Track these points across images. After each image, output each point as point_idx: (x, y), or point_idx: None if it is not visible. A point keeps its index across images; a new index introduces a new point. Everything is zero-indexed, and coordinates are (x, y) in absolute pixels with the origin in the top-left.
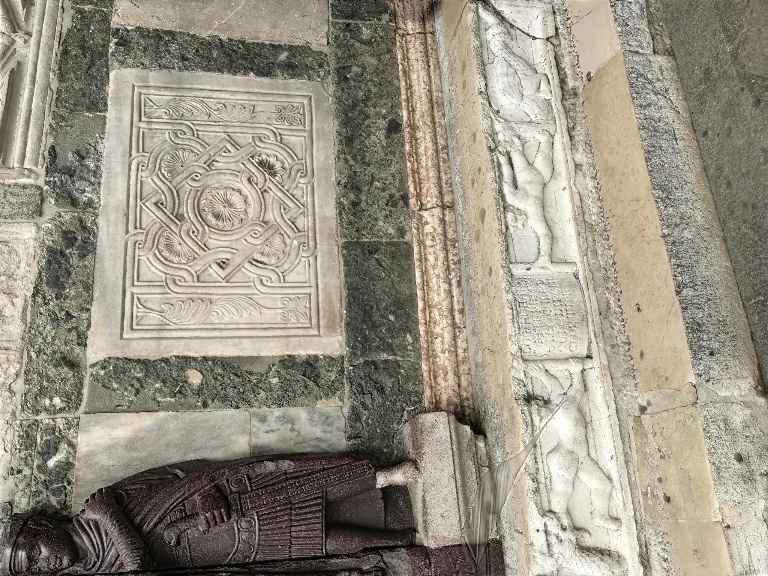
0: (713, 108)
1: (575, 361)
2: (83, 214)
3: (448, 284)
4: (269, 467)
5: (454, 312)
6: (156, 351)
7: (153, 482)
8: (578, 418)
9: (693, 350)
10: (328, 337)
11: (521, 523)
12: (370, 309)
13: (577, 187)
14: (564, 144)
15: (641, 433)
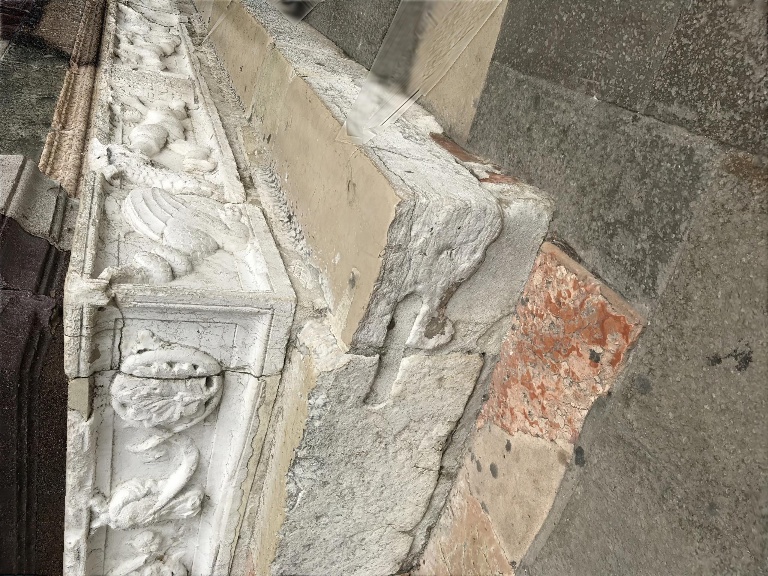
0: None
1: (176, 99)
2: None
3: (78, 155)
4: None
5: (81, 170)
6: None
7: None
8: (171, 115)
9: None
10: None
11: None
12: None
13: None
14: (186, 43)
15: (249, 130)
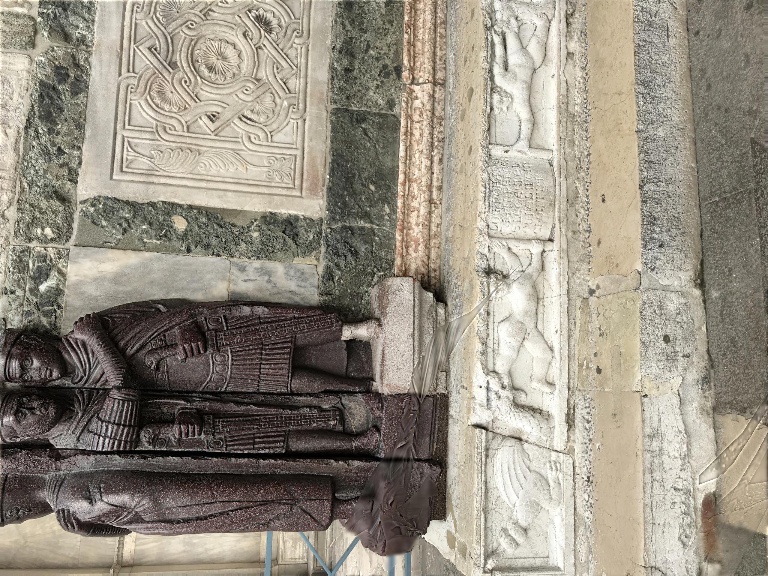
0: (709, 7)
1: (537, 242)
2: (76, 51)
3: (430, 160)
4: (245, 311)
5: (432, 188)
6: (144, 195)
7: (137, 313)
8: (532, 294)
9: (645, 241)
10: (310, 199)
11: (467, 380)
12: (352, 177)
13: (566, 76)
14: (560, 30)
15: (587, 313)
